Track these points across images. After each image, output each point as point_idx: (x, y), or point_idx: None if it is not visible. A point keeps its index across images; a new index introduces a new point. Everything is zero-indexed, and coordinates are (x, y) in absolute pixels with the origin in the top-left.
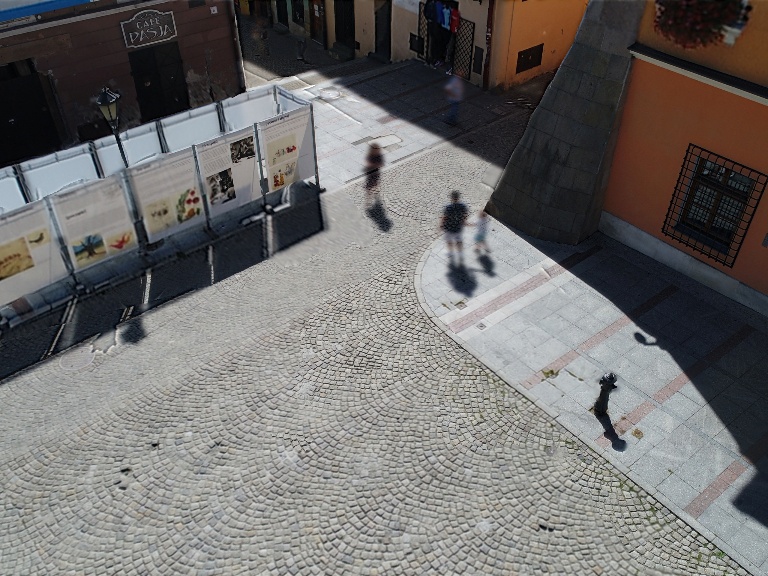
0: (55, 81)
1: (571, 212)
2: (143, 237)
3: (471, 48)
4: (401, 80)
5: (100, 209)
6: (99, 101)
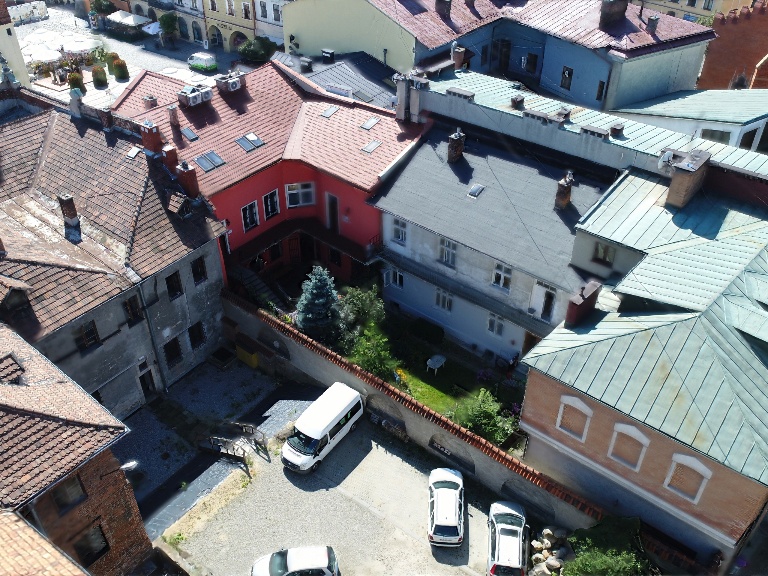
0: None
1: (83, 12)
2: None
3: None
4: (70, 5)
5: None
6: None
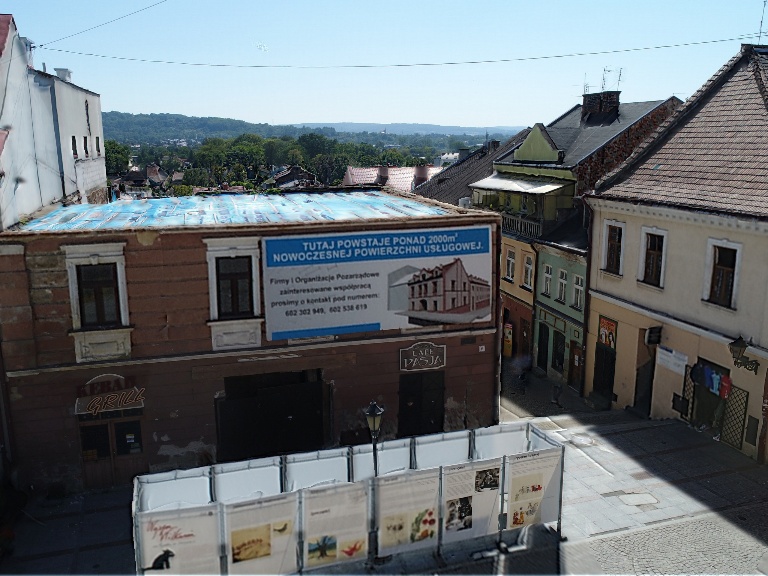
0: (334, 390)
1: None
2: (374, 549)
3: (744, 417)
4: (661, 438)
5: (342, 511)
6: (368, 412)
